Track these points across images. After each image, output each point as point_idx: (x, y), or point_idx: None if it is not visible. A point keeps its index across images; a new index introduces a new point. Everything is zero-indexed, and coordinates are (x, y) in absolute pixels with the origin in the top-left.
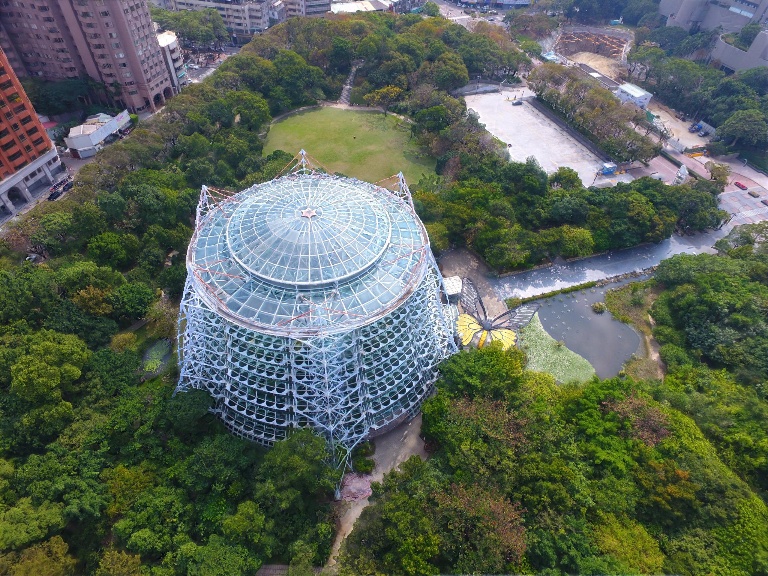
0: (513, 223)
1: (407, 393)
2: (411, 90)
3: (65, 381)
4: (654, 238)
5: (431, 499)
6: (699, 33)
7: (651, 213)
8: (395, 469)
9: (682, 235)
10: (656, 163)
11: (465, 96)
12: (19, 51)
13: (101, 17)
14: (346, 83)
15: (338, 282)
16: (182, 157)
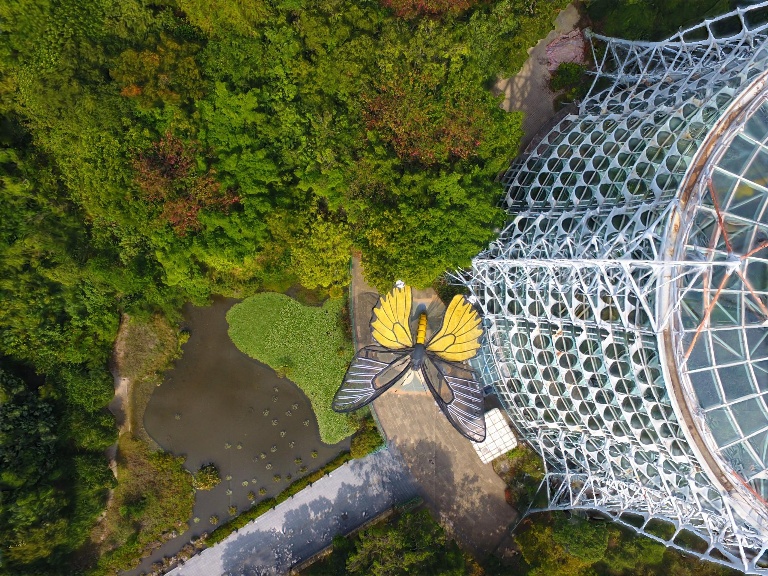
0: None
1: None
2: None
3: None
4: None
5: None
6: None
7: None
8: (521, 87)
9: None
10: None
11: None
12: None
13: None
14: None
15: None
16: None
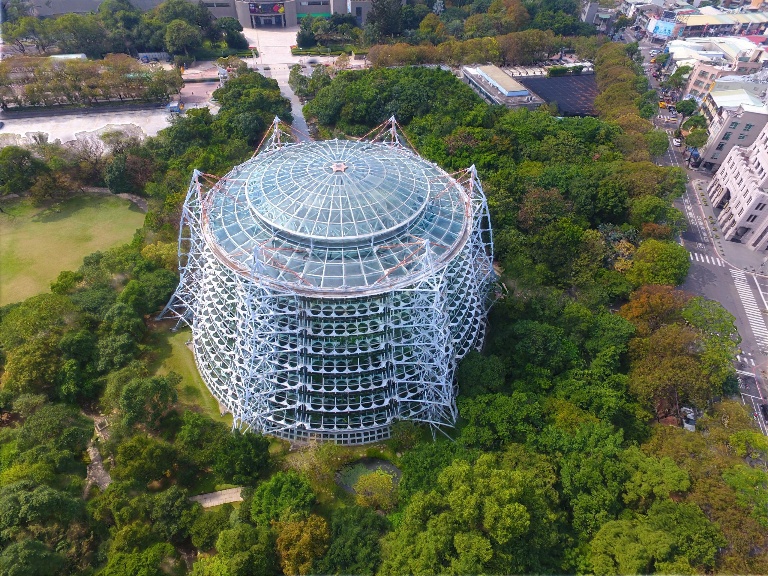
0: None
1: None
2: None
3: None
4: (290, 106)
5: None
6: None
7: None
8: None
9: None
10: None
11: None
12: None
13: None
14: None
15: None
16: None
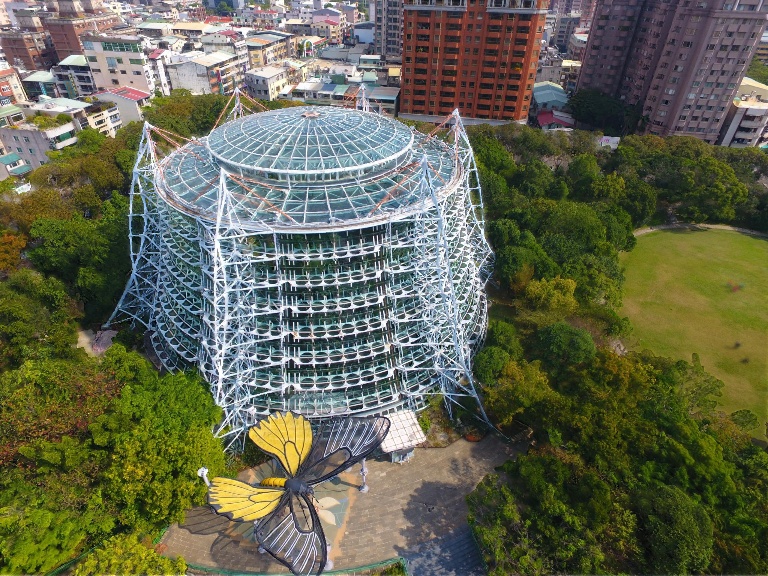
0: None
1: None
2: None
3: None
4: None
5: None
6: None
7: None
8: None
9: None
10: None
11: None
12: None
13: (681, 47)
14: None
15: None
16: None
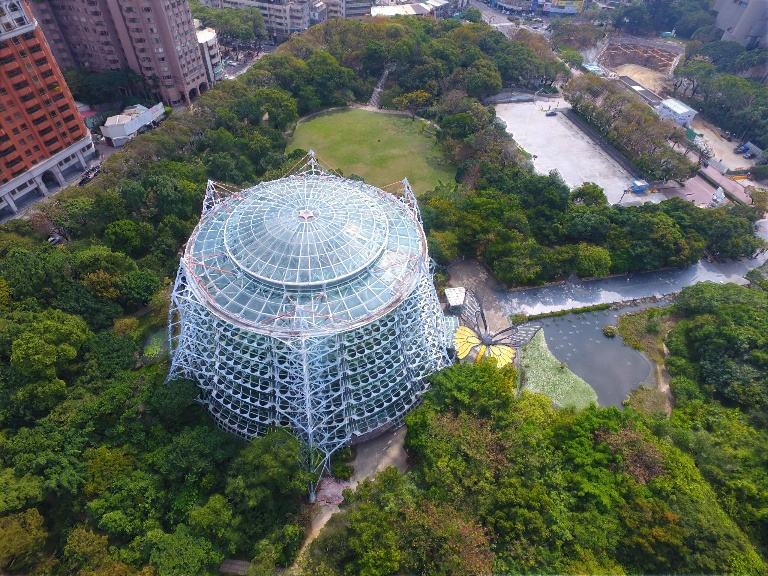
0: (527, 237)
1: (394, 402)
2: (441, 96)
3: (61, 360)
4: (678, 263)
5: (403, 513)
6: (756, 49)
7: (677, 236)
8: None
9: (711, 262)
10: (693, 184)
11: (497, 104)
12: (69, 42)
13: (143, 13)
14: (377, 86)
15: (327, 285)
16: (208, 151)
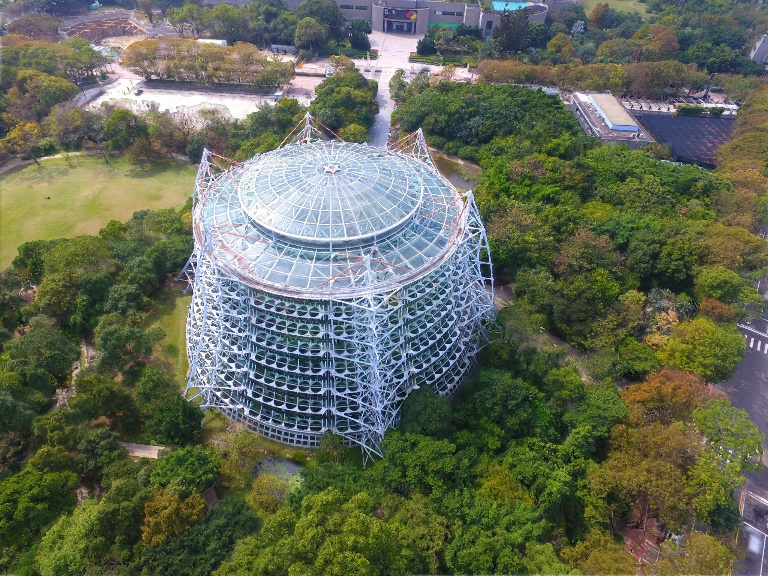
0: None
1: None
2: None
3: None
4: (377, 109)
5: None
6: None
7: None
8: None
9: None
10: (292, 80)
11: None
12: None
13: None
14: None
15: None
16: None
